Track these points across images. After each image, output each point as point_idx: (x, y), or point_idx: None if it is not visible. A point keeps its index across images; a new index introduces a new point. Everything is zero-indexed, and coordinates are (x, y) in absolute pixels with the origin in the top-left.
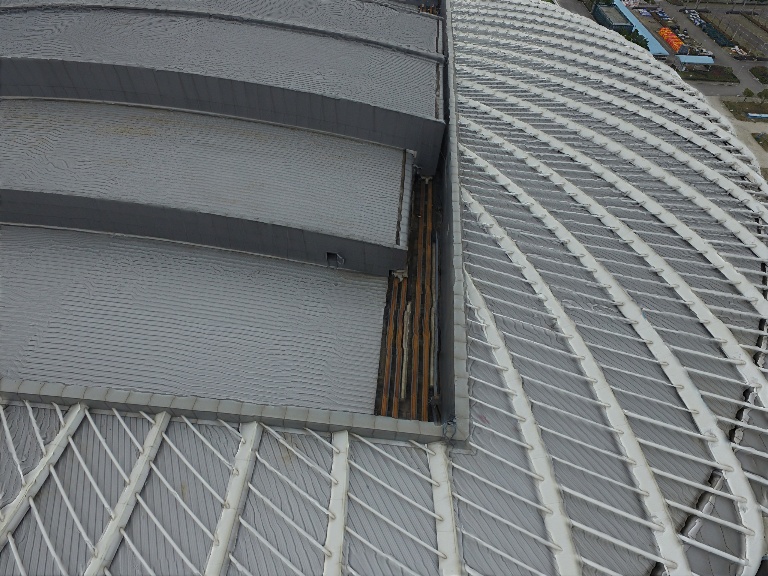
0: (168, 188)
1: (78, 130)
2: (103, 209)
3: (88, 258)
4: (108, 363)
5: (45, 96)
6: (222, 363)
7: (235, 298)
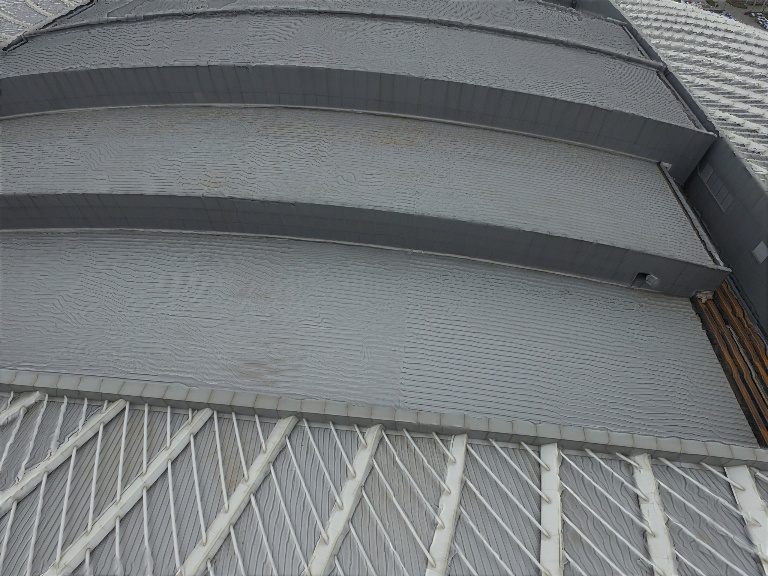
0: (475, 204)
1: (346, 141)
2: (417, 226)
3: (385, 275)
4: (484, 392)
5: (292, 104)
6: (586, 392)
7: (562, 321)
